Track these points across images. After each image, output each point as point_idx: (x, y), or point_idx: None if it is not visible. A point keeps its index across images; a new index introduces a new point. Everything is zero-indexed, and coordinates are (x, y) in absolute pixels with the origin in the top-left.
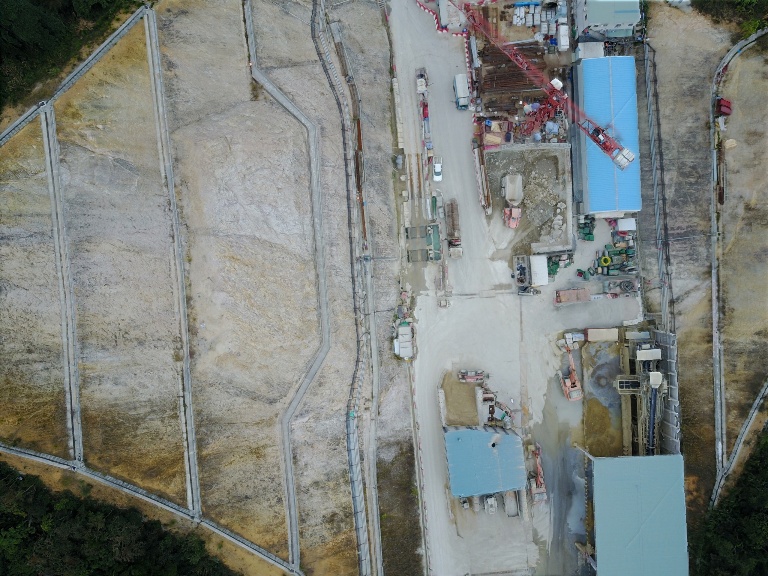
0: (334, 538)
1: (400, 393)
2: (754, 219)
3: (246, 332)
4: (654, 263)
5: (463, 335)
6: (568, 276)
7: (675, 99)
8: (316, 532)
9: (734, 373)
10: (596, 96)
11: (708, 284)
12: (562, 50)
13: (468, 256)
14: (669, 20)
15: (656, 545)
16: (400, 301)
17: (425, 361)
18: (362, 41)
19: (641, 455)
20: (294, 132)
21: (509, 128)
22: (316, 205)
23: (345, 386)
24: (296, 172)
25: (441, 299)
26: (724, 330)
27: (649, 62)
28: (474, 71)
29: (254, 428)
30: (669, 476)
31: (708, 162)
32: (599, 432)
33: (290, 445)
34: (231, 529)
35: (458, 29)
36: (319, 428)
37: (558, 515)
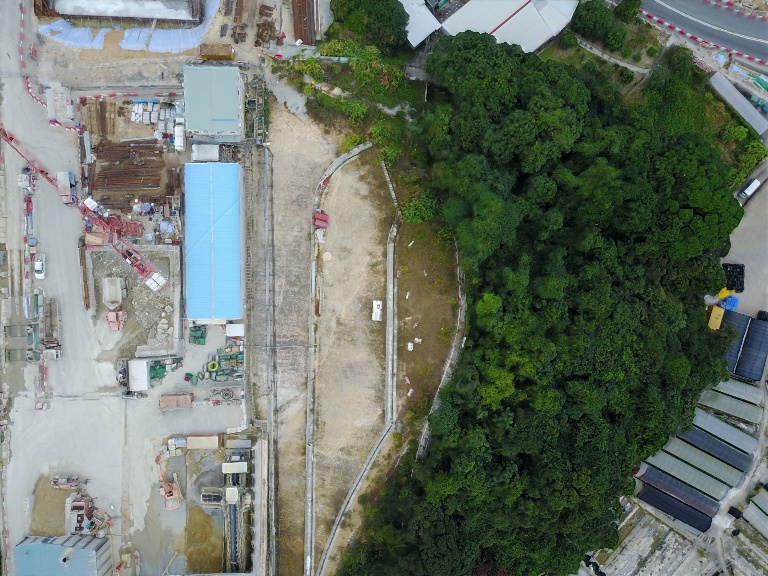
0: None
1: None
2: (342, 334)
3: None
4: (264, 369)
5: (62, 438)
6: (177, 380)
7: (286, 206)
8: None
9: (323, 487)
10: (197, 202)
11: (305, 395)
12: (180, 150)
13: (71, 357)
14: (287, 126)
15: None
16: None
17: (19, 465)
18: None
19: (227, 569)
20: None
21: (112, 229)
22: None
23: None
24: None
25: (39, 401)
26: (317, 443)
27: (268, 166)
28: (87, 167)
29: None
30: None
31: (308, 273)
32: (200, 541)
33: None
34: None
35: (73, 123)
36: None
37: None
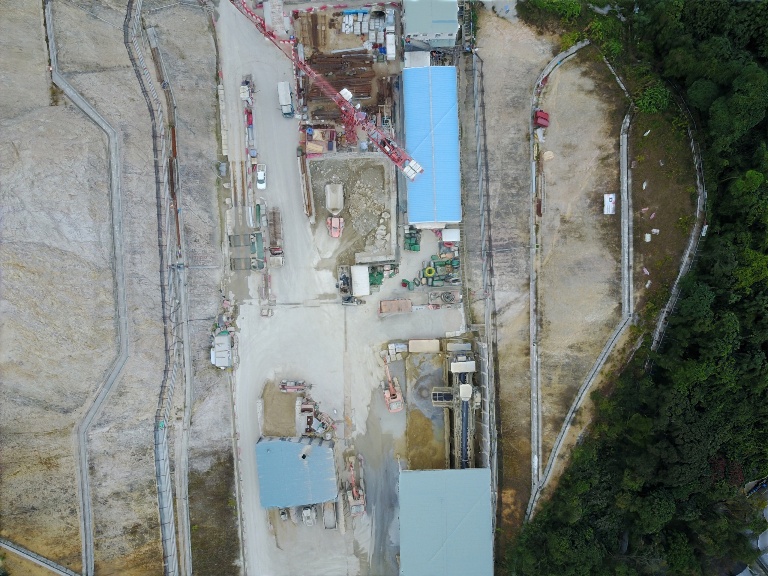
0: (136, 550)
1: (219, 403)
2: (568, 232)
3: (30, 341)
4: (479, 274)
5: (286, 345)
6: (393, 286)
7: (499, 110)
8: (115, 544)
9: (550, 386)
10: (416, 106)
11: (527, 296)
12: (390, 59)
13: (292, 265)
14: (496, 30)
15: (460, 559)
16: (222, 310)
17: (247, 371)
18: (183, 47)
19: (456, 468)
20: (91, 138)
21: (331, 137)
22: (116, 212)
23: (152, 396)
24: (91, 179)
25: (264, 308)
26: (541, 343)
27: (477, 72)
28: (301, 79)
29: (45, 438)
30: (475, 490)
31: (528, 174)
32: (421, 444)
33: (86, 455)
34: (13, 541)
35: (286, 36)
36: (122, 438)
37: (380, 527)
